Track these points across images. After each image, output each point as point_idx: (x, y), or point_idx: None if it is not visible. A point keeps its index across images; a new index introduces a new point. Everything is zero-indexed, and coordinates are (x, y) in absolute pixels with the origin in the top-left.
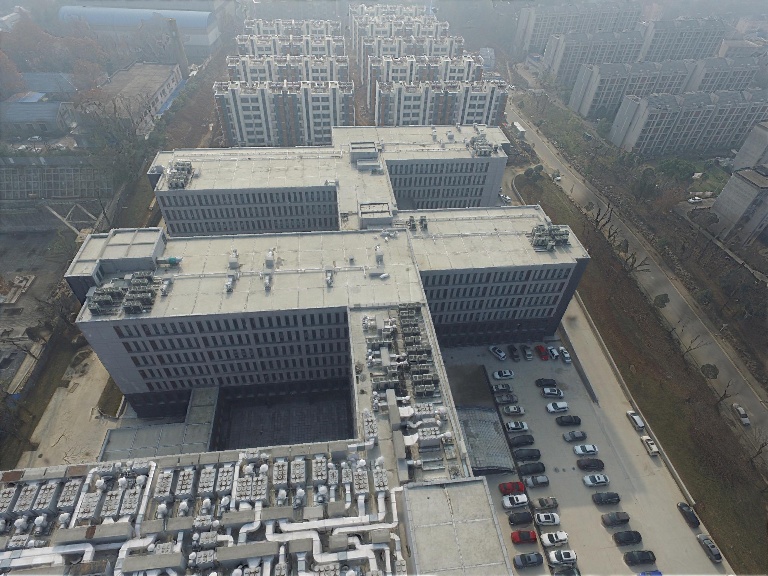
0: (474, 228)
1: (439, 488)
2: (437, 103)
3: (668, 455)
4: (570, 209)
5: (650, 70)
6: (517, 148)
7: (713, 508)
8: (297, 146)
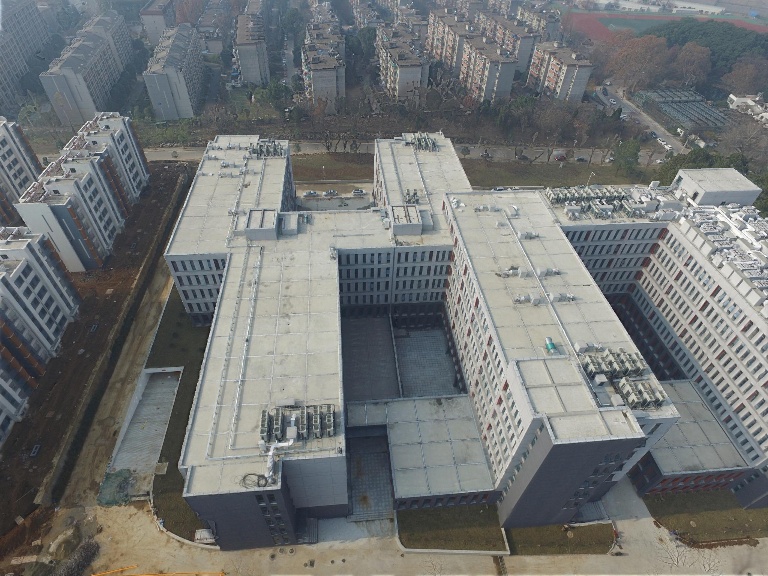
0: (411, 173)
1: (697, 183)
2: (102, 173)
3: (518, 186)
4: (298, 158)
5: (91, 51)
6: (171, 165)
7: (543, 182)
8: (220, 288)
